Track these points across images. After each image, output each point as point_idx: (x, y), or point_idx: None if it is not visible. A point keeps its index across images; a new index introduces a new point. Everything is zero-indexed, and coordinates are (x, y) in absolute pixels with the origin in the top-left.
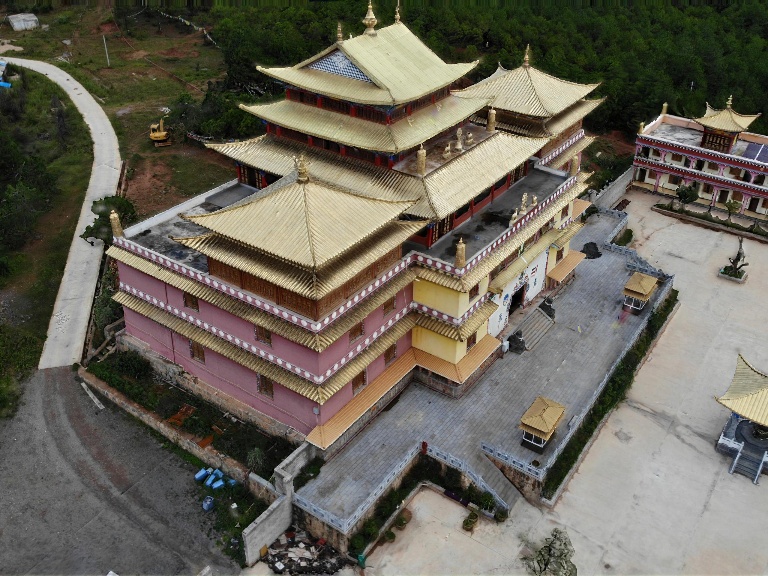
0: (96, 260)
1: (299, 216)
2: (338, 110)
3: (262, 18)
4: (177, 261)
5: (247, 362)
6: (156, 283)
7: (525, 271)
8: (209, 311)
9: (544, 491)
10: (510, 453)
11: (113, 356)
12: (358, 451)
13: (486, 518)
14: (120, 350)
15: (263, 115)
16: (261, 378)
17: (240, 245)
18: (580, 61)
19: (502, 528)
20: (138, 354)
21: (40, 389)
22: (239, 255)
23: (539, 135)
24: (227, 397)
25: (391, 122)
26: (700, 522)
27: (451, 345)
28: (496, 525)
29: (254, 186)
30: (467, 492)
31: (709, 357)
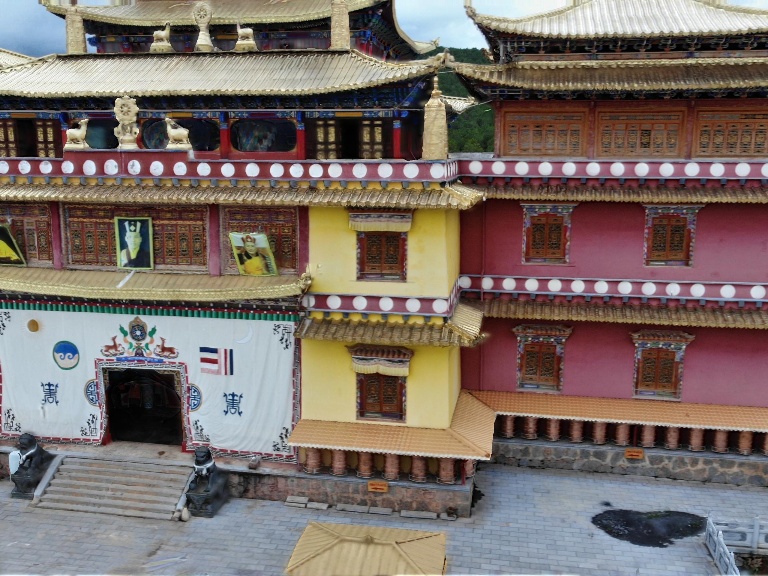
0: None
1: None
2: None
3: None
4: None
5: None
6: None
7: (156, 328)
8: None
9: None
10: None
11: None
12: None
13: None
14: None
15: None
16: None
17: None
18: None
19: None
20: None
21: None
22: None
23: None
24: None
25: None
26: None
27: None
28: None
29: None
30: None
31: None
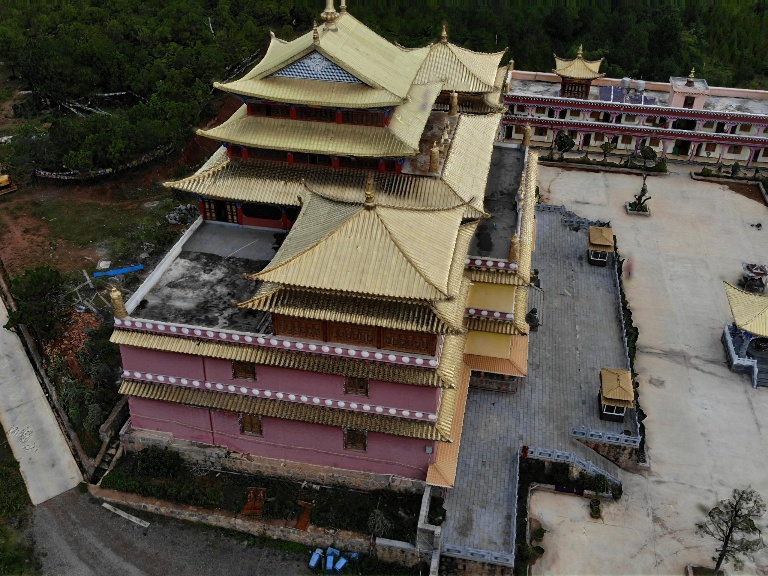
0: (17, 350)
1: (388, 246)
2: (319, 119)
3: (37, 22)
4: (221, 329)
5: (338, 421)
6: (187, 361)
7: None
8: (273, 376)
9: (638, 456)
10: (596, 430)
11: (123, 460)
12: (465, 477)
13: (605, 500)
14: (128, 450)
15: (229, 138)
16: (348, 433)
17: (320, 293)
18: (394, 28)
19: (623, 504)
20: (159, 448)
21: (54, 529)
22: (327, 305)
23: (485, 111)
24: (298, 465)
25: (387, 123)
26: (763, 439)
27: (504, 341)
28: (617, 503)
29: (225, 220)
30: (581, 481)
31: (670, 289)
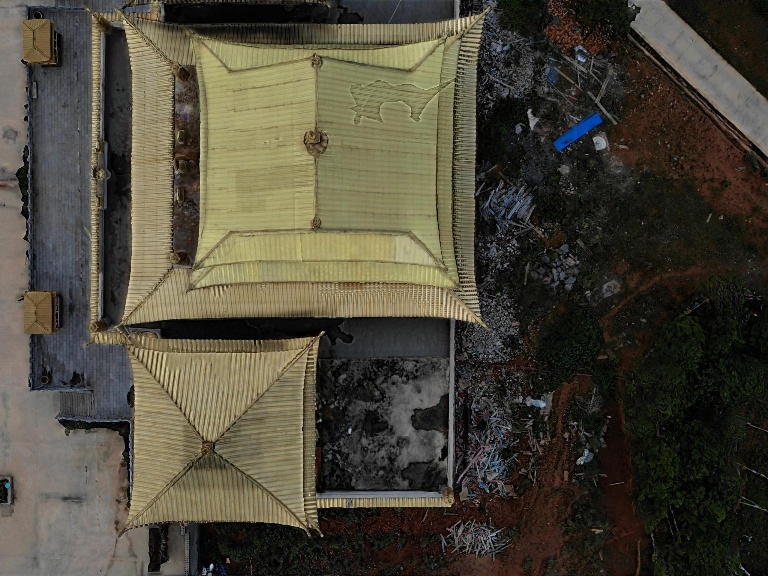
0: None
1: None
2: None
3: None
4: None
5: None
6: None
7: None
8: None
9: None
10: (65, 21)
11: None
12: None
13: None
14: None
15: None
16: None
17: None
18: None
19: None
20: None
21: None
22: None
23: (148, 338)
24: None
25: None
26: None
27: None
28: None
29: None
30: None
31: None
